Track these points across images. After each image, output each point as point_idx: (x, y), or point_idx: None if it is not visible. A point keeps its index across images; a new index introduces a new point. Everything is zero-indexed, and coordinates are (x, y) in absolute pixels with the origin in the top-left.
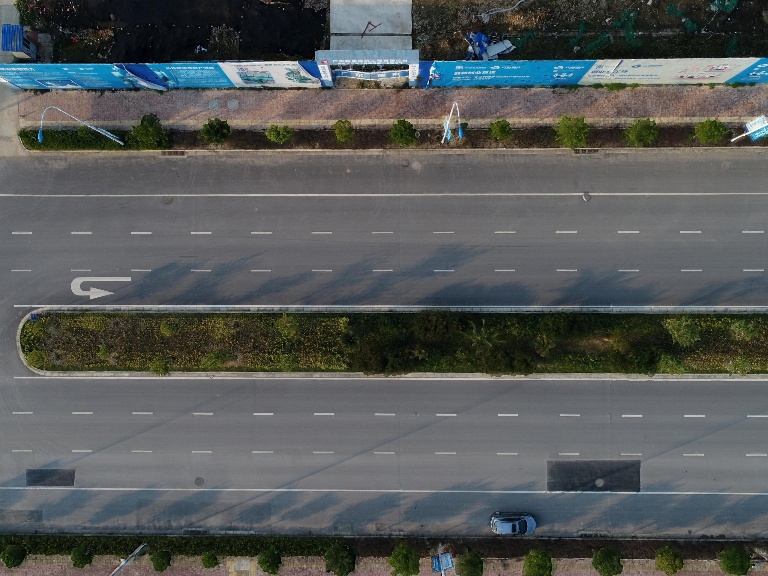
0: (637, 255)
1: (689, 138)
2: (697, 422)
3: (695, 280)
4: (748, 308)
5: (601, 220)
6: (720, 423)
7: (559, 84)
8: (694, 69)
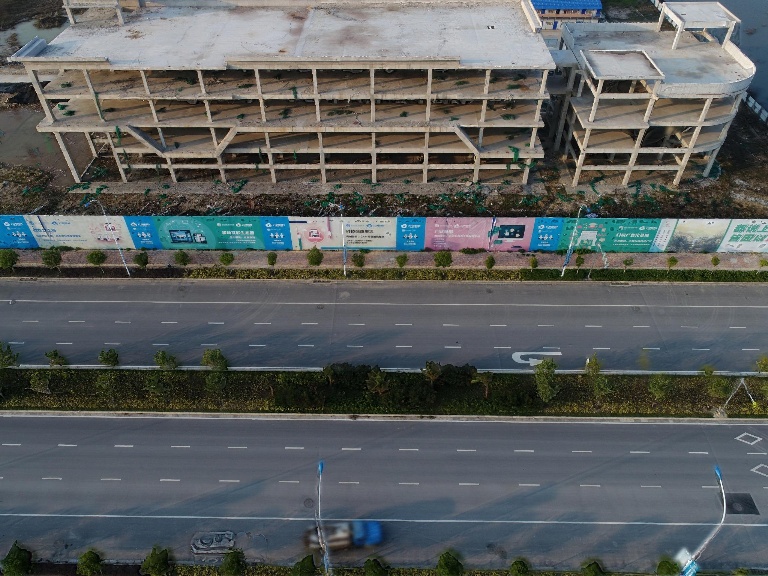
0: (28, 334)
1: (100, 273)
2: (11, 450)
3: (64, 349)
4: (96, 367)
5: (15, 314)
6: (31, 450)
7: (29, 248)
8: (96, 229)
